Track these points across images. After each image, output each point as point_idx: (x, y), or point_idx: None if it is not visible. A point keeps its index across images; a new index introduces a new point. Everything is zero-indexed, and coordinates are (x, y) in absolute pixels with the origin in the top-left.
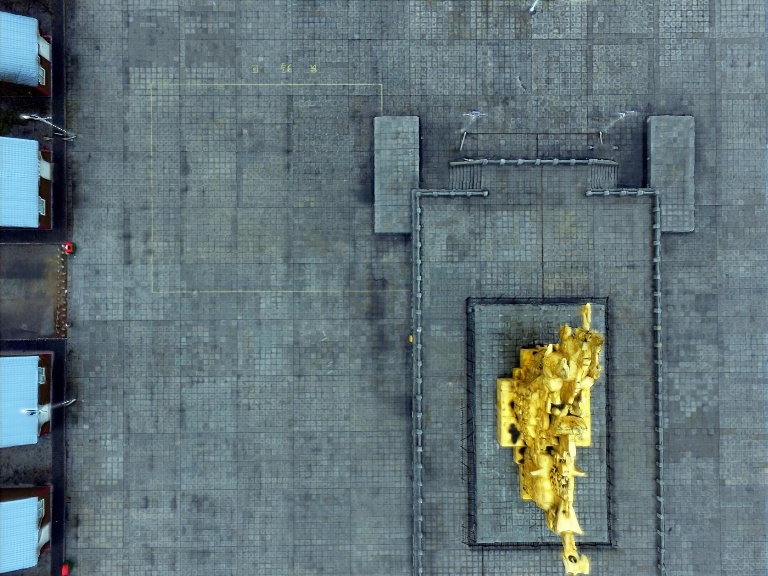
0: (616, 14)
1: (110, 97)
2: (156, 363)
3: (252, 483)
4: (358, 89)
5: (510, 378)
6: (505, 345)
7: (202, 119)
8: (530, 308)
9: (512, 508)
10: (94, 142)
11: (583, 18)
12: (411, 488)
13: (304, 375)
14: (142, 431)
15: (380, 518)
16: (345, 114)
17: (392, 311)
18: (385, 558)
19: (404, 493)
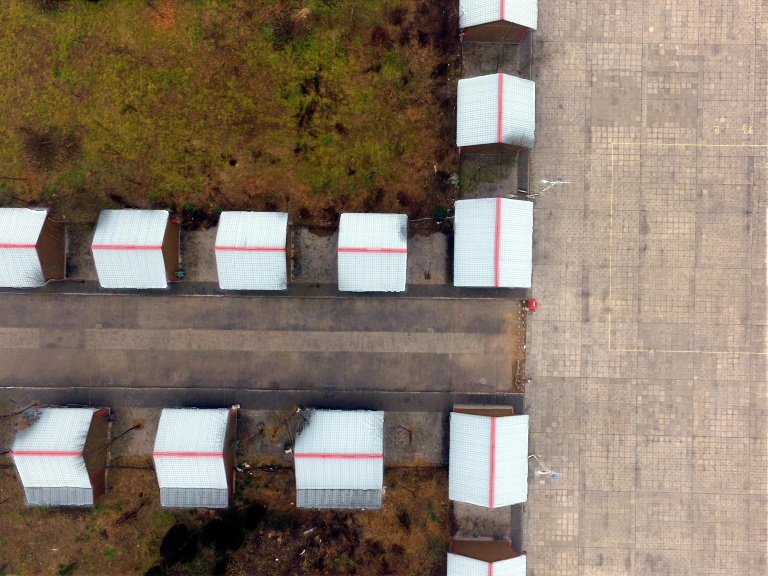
0: None
1: (572, 155)
2: (612, 421)
3: (707, 544)
4: None
5: None
6: None
7: (662, 179)
8: None
9: None
10: (555, 200)
11: None
12: None
13: (760, 437)
14: (598, 488)
15: None
16: None
17: None
18: None
19: None
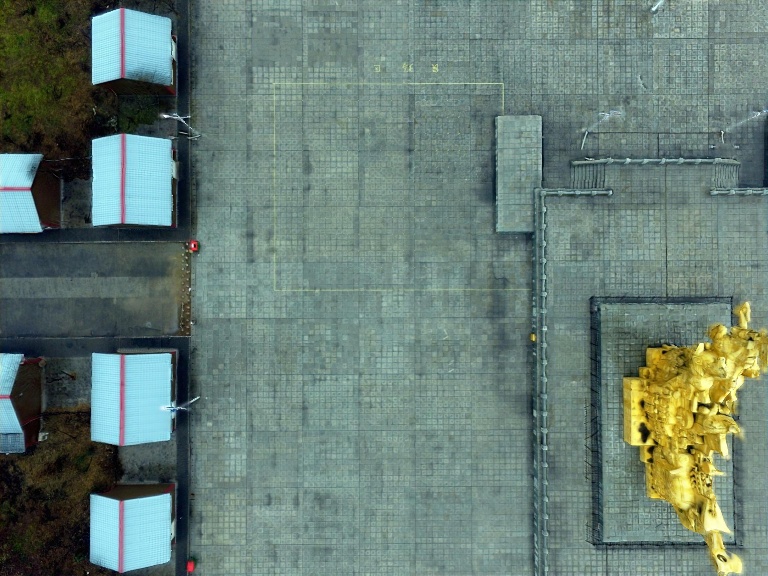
0: (738, 13)
1: (234, 96)
2: (279, 361)
3: (374, 481)
4: (479, 88)
5: (637, 377)
6: (631, 344)
7: (324, 118)
8: (656, 307)
9: (638, 507)
10: (218, 141)
11: (704, 17)
12: (532, 487)
13: (425, 373)
14: (265, 429)
15: (501, 516)
16: (466, 113)
17: (513, 310)
18: (506, 556)
19: (525, 492)
